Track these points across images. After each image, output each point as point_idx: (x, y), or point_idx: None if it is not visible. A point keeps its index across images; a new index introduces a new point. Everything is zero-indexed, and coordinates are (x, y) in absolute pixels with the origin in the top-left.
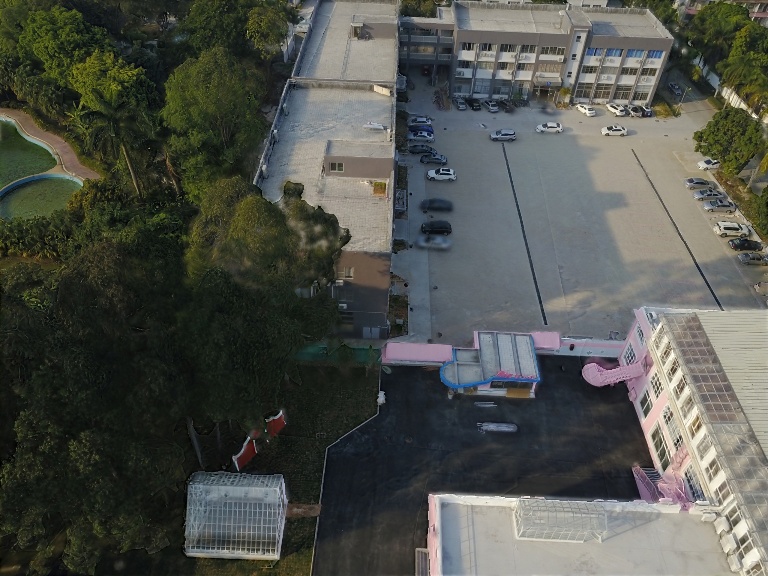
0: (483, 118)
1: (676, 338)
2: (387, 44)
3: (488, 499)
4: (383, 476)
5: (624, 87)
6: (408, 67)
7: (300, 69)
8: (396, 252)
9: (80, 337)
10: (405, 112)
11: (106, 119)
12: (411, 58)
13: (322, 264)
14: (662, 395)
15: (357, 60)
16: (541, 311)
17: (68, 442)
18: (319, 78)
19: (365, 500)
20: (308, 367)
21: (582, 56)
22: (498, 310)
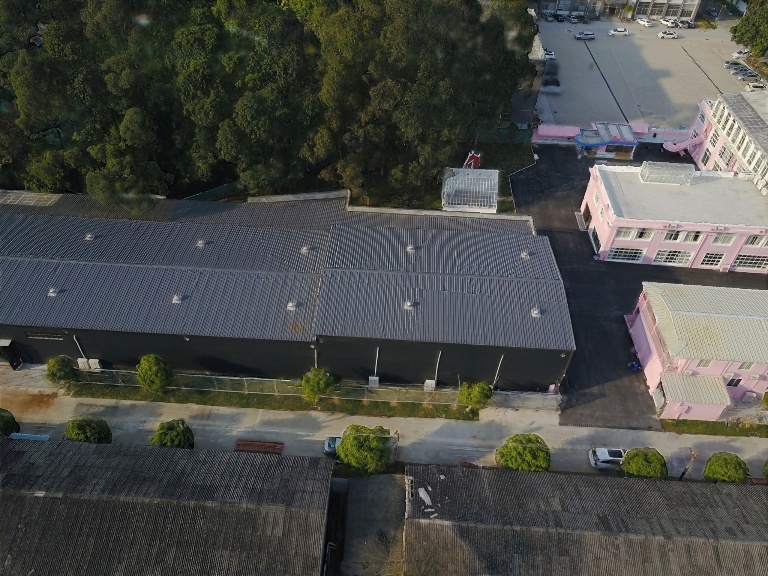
0: (567, 26)
1: (728, 103)
2: None
3: (625, 167)
4: (547, 187)
5: (674, 6)
6: None
7: None
8: None
9: (442, 34)
10: None
11: None
12: None
13: None
14: (718, 142)
15: None
16: None
17: (439, 82)
18: None
19: (539, 195)
20: (484, 143)
21: None
22: None
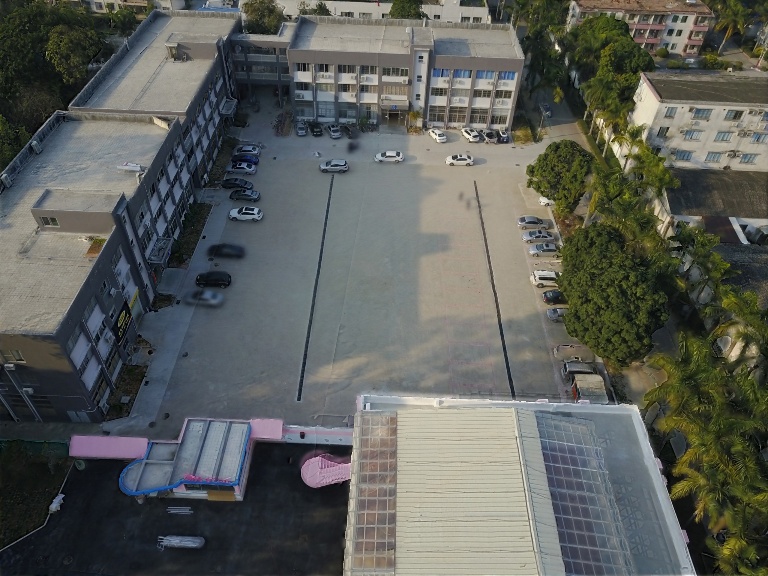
0: (321, 145)
1: (362, 446)
2: (205, 66)
3: None
4: None
5: (480, 110)
6: (251, 88)
7: (91, 96)
8: (156, 310)
9: None
10: (235, 139)
11: None
12: (252, 78)
13: None
14: None
15: (161, 85)
16: (299, 383)
17: None
18: (99, 108)
19: None
20: None
21: (428, 78)
22: (249, 382)
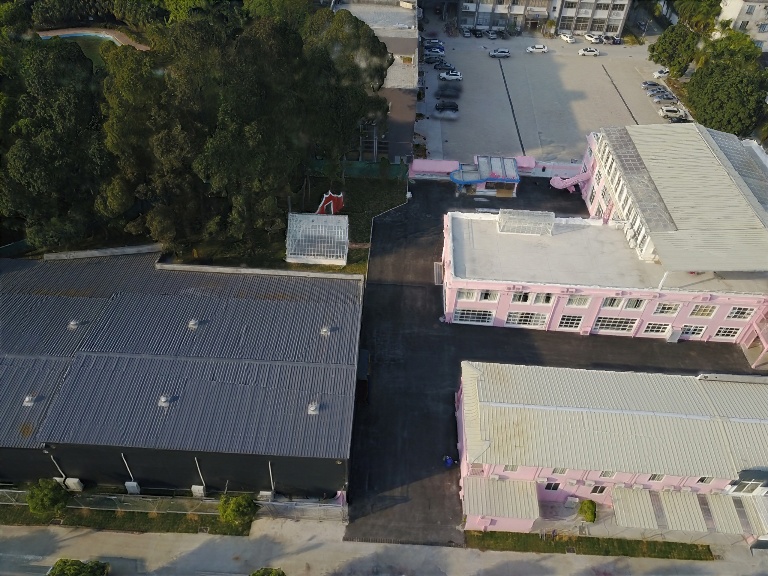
0: (484, 43)
1: (610, 139)
2: None
3: (481, 214)
4: (412, 231)
5: (599, 20)
6: (424, 4)
7: None
8: (417, 121)
9: (250, 71)
10: None
11: (205, 14)
12: None
13: (378, 68)
14: (601, 181)
15: None
16: None
17: (245, 127)
18: None
19: (400, 242)
20: (357, 179)
21: None
22: (492, 155)
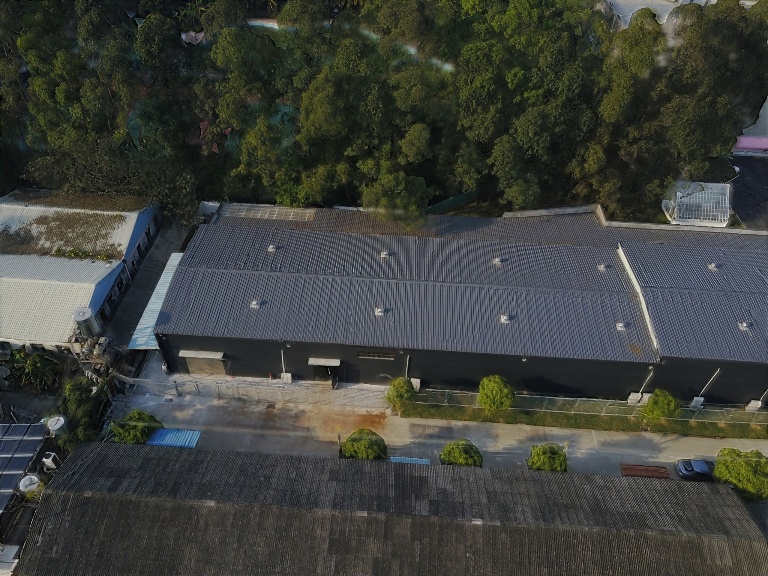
0: None
1: None
2: None
3: None
4: (761, 200)
5: None
6: None
7: None
8: None
9: None
10: None
11: None
12: None
13: None
14: None
15: None
16: None
17: (717, 99)
18: None
19: (758, 209)
20: None
21: None
22: None
